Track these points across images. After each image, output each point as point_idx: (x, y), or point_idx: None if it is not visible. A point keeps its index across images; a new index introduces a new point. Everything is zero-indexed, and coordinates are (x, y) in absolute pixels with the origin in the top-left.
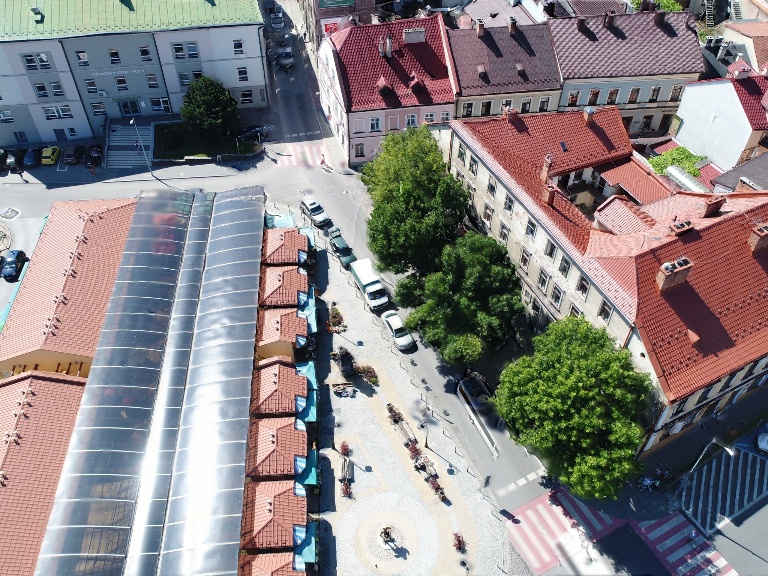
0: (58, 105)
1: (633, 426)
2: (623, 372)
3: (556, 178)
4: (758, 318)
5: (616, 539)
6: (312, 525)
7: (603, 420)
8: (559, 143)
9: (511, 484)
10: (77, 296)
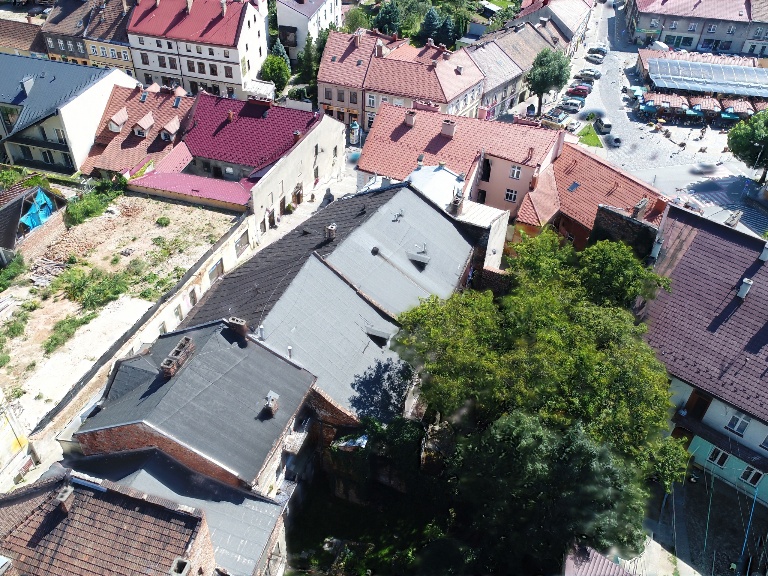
0: None
1: (767, 137)
2: None
3: None
4: None
5: (715, 185)
6: (703, 114)
7: (765, 123)
8: None
9: (738, 167)
10: None
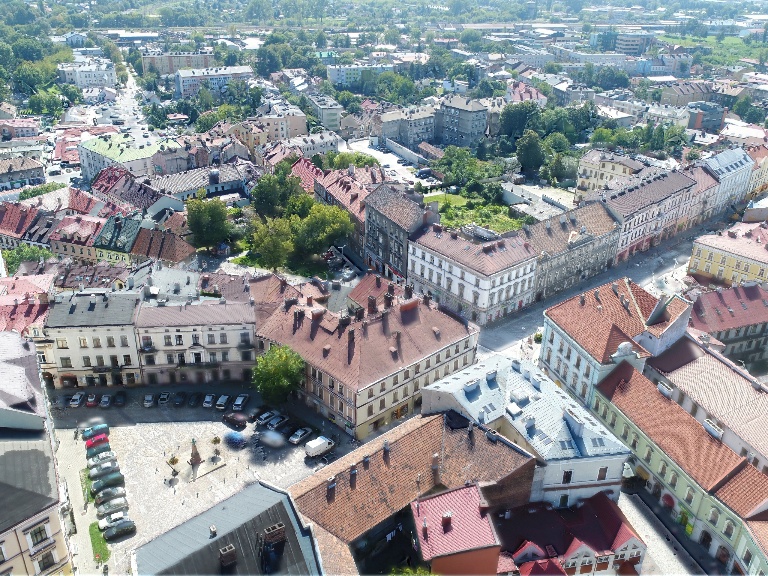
0: None
1: None
2: None
3: None
4: (8, 227)
5: None
6: None
7: None
8: None
9: None
10: (8, 193)
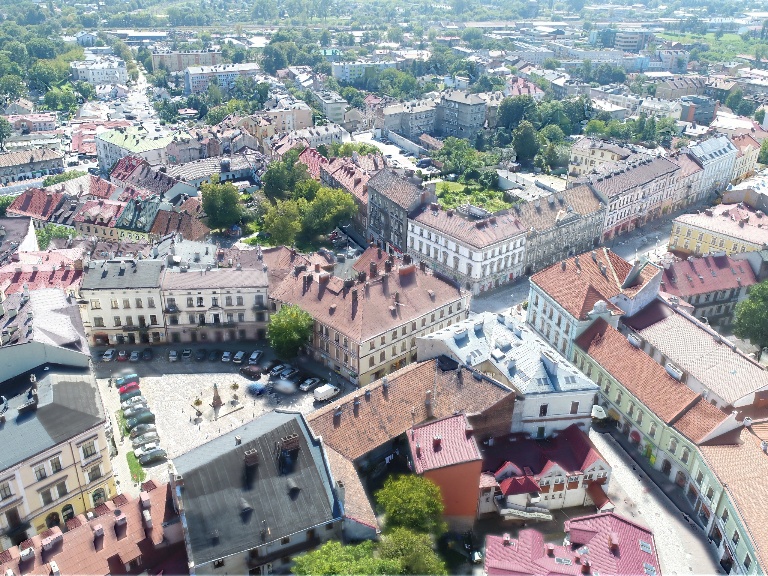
0: None
1: None
2: (5, 200)
3: (97, 198)
4: None
5: None
6: None
7: None
8: None
9: None
10: None
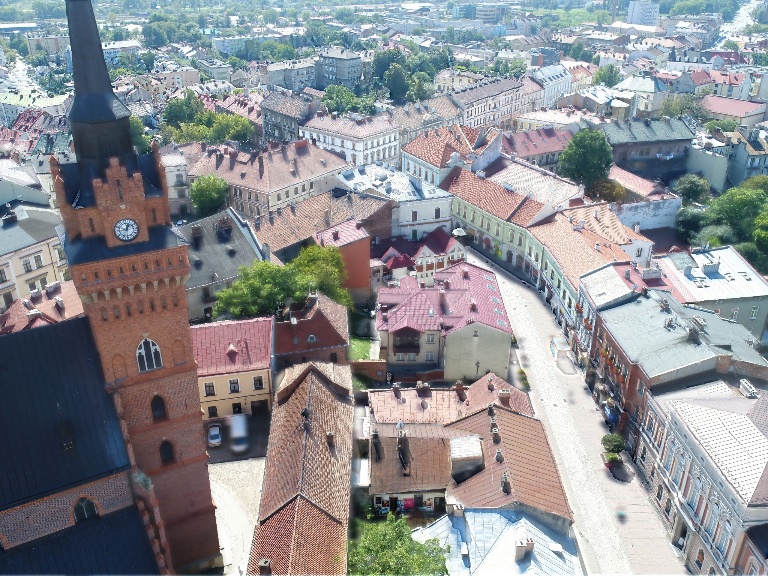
0: (5, 123)
1: None
2: None
3: None
4: None
5: None
6: None
7: None
8: (5, 135)
9: None
10: None
